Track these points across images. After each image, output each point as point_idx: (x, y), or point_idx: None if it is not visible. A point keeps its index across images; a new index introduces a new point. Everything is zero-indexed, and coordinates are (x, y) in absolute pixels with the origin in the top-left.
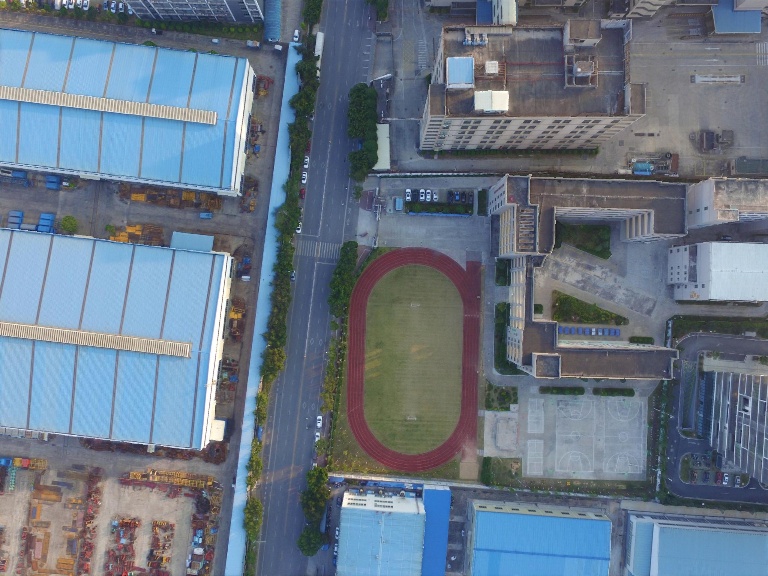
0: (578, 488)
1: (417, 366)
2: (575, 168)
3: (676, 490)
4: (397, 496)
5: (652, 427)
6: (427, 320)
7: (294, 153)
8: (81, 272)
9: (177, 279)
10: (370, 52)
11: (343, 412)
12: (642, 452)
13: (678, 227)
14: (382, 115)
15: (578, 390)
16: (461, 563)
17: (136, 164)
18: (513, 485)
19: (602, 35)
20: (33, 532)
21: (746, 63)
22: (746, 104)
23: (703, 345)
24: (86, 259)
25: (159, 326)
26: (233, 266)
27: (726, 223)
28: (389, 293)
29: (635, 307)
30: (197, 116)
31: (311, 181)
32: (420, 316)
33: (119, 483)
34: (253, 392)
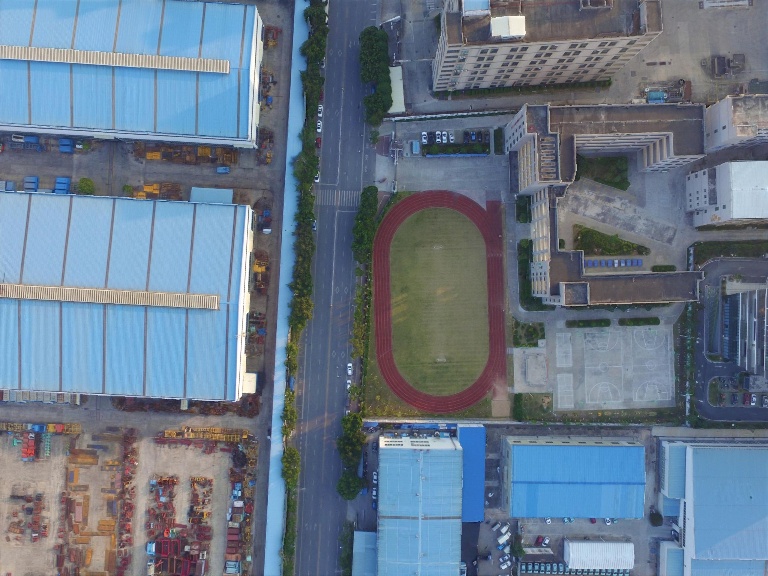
0: (609, 418)
1: (443, 308)
2: (589, 101)
3: (705, 414)
4: (432, 437)
5: (679, 354)
6: (450, 262)
7: (308, 101)
8: (103, 231)
9: (200, 232)
10: None
11: (373, 358)
12: (670, 379)
13: (697, 148)
14: (394, 57)
15: (604, 322)
16: (498, 499)
17: (151, 118)
18: (545, 419)
19: None
20: (72, 496)
21: None
22: (755, 27)
23: (725, 270)
24: (107, 218)
25: (185, 280)
26: (254, 219)
27: (741, 147)
28: (411, 237)
29: (656, 236)
30: (210, 66)
31: (326, 130)
32: (443, 258)
33: (154, 442)
34: (282, 343)
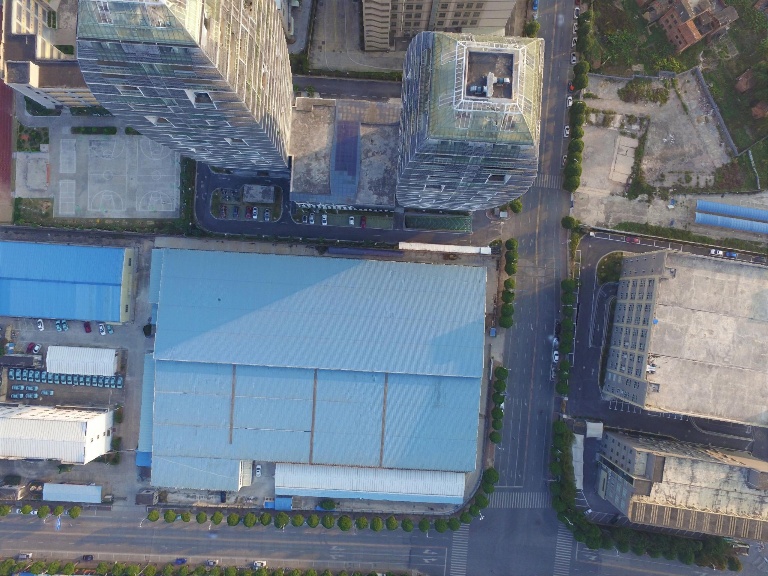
0: (109, 226)
1: None
2: None
3: (207, 226)
4: None
5: None
6: None
7: None
8: None
9: None
10: None
11: None
12: (175, 190)
13: None
14: None
15: (108, 129)
16: None
17: None
18: (43, 224)
19: None
20: None
21: None
22: None
23: None
24: None
25: None
26: None
27: None
28: None
29: None
30: None
31: None
32: None
33: None
34: None
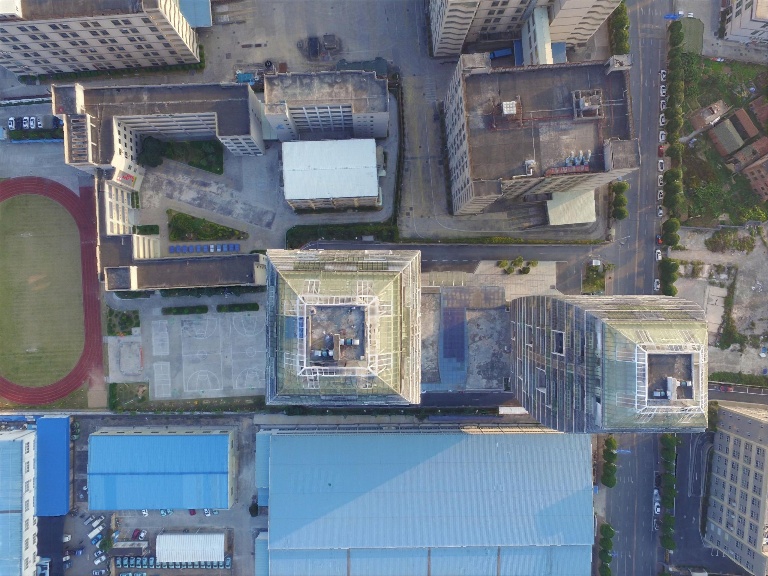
0: (207, 407)
1: (35, 297)
2: None
3: None
4: (18, 429)
5: None
6: (42, 250)
7: None
8: None
9: None
10: None
11: None
12: None
13: (244, 128)
14: None
15: (200, 308)
16: None
17: None
18: (140, 409)
19: None
20: None
21: None
22: (353, 8)
23: None
24: None
25: None
26: None
27: (339, 129)
28: (1, 225)
29: (254, 221)
30: None
31: None
32: (35, 246)
33: None
34: None
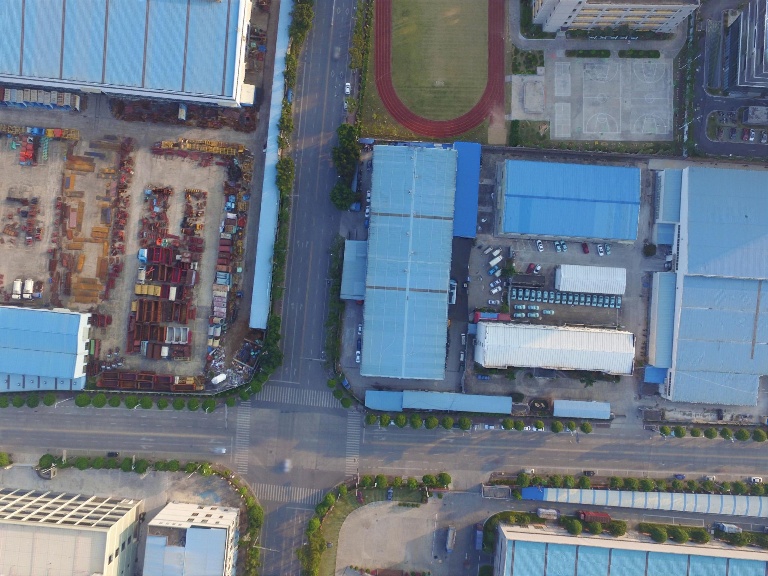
0: (606, 148)
1: (443, 33)
2: None
3: (703, 148)
4: None
5: (678, 88)
6: None
7: None
8: None
9: None
10: None
11: (371, 80)
12: (668, 113)
13: None
14: None
15: (604, 51)
16: (491, 225)
17: None
18: None
19: None
20: (67, 202)
21: None
22: None
23: (727, 5)
24: None
25: None
26: None
27: None
28: None
29: None
30: None
31: None
32: None
33: (151, 153)
34: (282, 53)
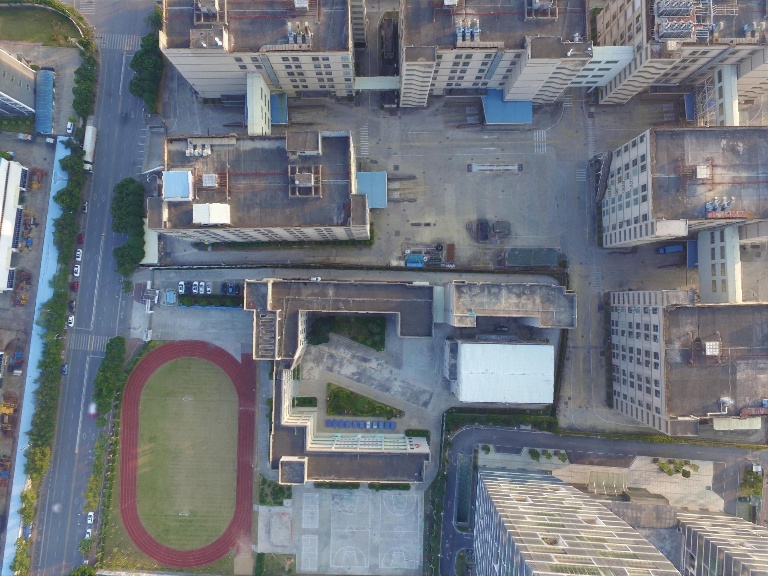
0: None
1: (191, 460)
2: (350, 259)
3: None
4: None
5: (428, 521)
6: (201, 413)
7: (59, 249)
8: None
9: None
10: (145, 143)
11: (116, 508)
12: (418, 547)
13: (426, 329)
14: None
15: (352, 484)
16: None
17: None
18: None
19: (329, 143)
20: None
21: (524, 151)
22: (524, 193)
23: (479, 438)
24: None
25: None
26: (4, 361)
27: None
28: (163, 386)
29: (411, 399)
30: None
31: (85, 274)
32: (194, 409)
33: None
34: (19, 490)
